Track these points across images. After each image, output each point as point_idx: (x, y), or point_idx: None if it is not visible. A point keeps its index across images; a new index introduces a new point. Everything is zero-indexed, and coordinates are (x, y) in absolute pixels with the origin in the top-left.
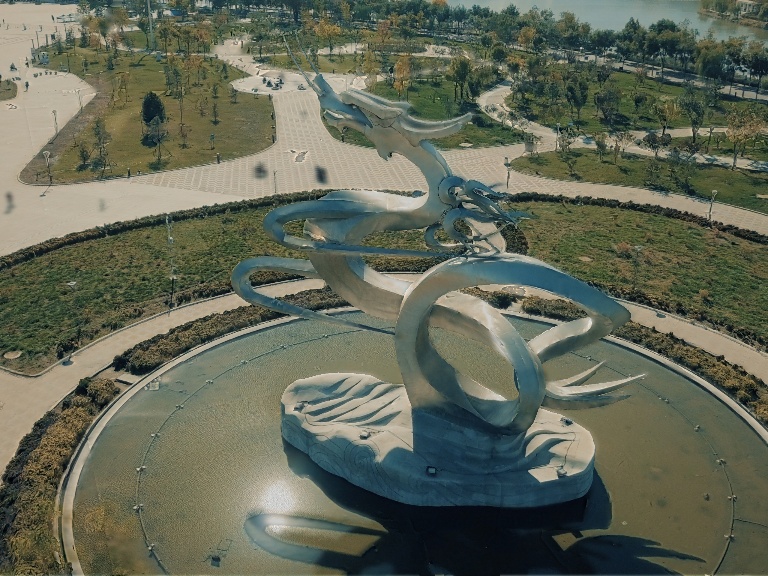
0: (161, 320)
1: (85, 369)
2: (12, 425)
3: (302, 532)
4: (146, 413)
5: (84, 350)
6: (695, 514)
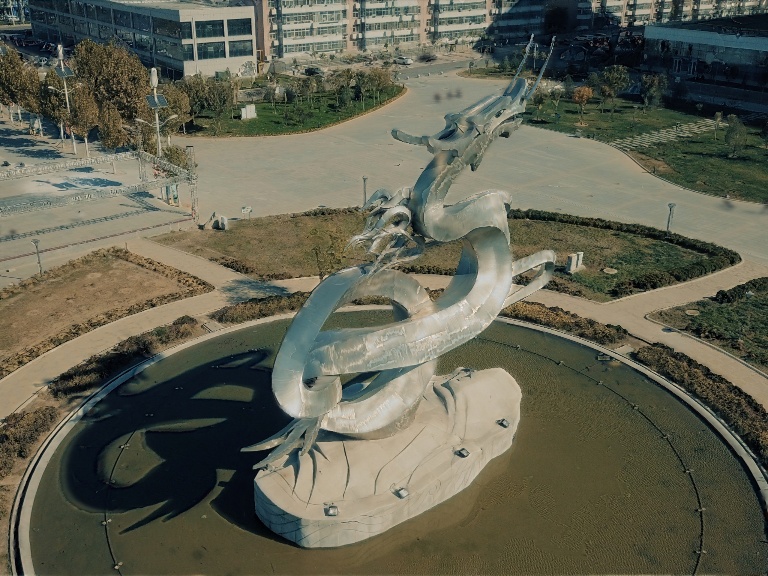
0: (760, 381)
1: (651, 335)
2: (568, 305)
3: (352, 375)
4: (558, 349)
5: (693, 338)
6: (164, 568)
